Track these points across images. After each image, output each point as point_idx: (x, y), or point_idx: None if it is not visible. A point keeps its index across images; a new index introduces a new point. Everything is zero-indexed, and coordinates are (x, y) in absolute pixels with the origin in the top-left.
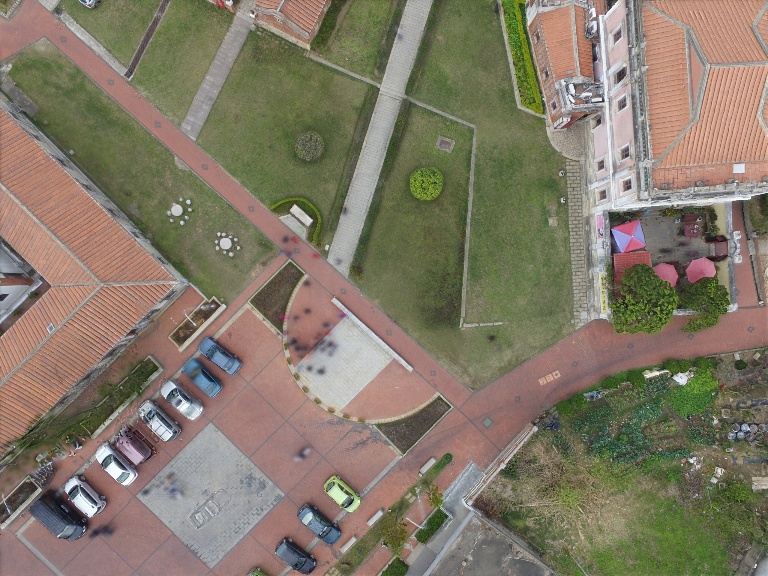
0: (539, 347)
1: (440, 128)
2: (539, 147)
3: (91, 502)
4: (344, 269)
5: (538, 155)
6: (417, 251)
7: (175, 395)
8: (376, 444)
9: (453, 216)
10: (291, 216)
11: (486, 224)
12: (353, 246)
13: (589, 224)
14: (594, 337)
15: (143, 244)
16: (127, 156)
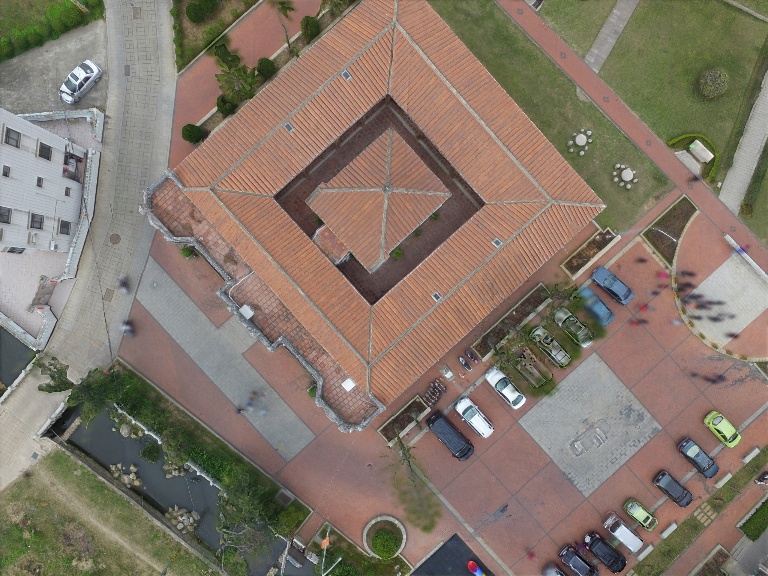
0: None
1: None
2: None
3: (488, 423)
4: (735, 207)
5: None
6: None
7: (575, 321)
8: (754, 382)
9: None
10: (686, 152)
11: None
12: (745, 185)
13: None
14: None
15: None
16: (529, 85)
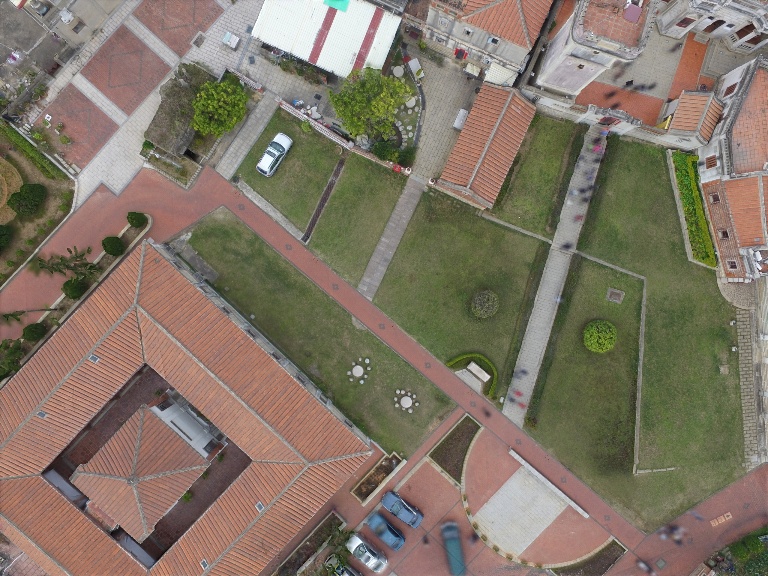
0: (710, 490)
1: (610, 280)
2: (710, 298)
3: None
4: (519, 420)
5: (709, 305)
6: (589, 400)
7: (363, 552)
8: None
9: (624, 365)
10: (466, 371)
11: (658, 373)
12: (527, 398)
13: (759, 371)
14: (765, 479)
15: (331, 410)
16: (305, 317)
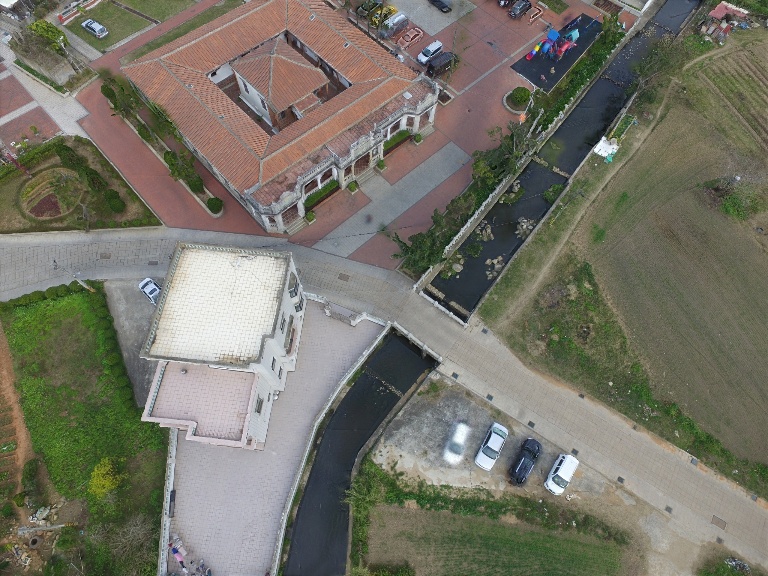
0: None
1: None
2: None
3: None
4: None
5: None
6: None
7: None
8: None
9: None
10: None
11: None
12: None
13: None
14: None
15: None
16: None
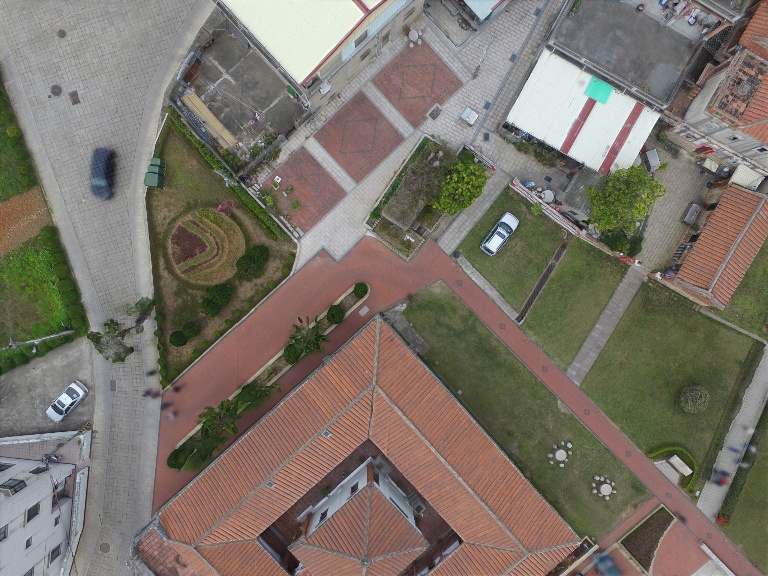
0: None
1: None
2: None
3: None
4: (712, 515)
5: None
6: None
7: None
8: None
9: None
10: (666, 462)
11: None
12: (723, 493)
13: None
14: None
15: None
16: (511, 397)
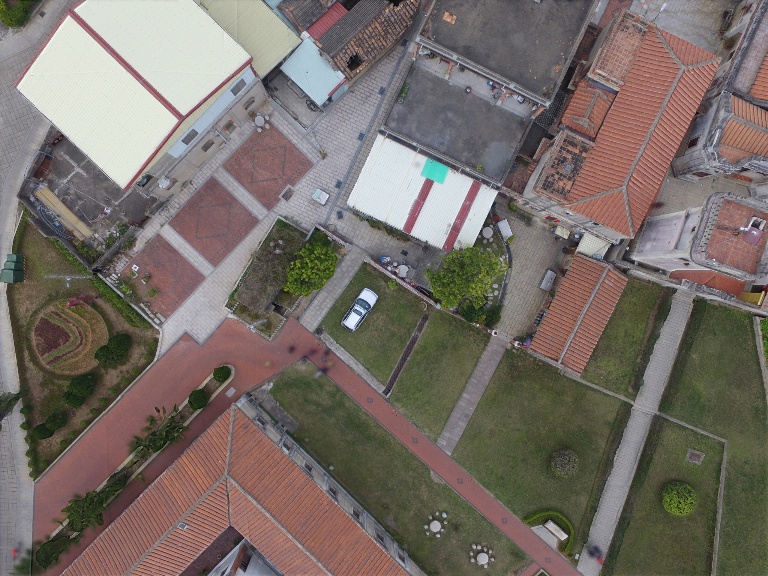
0: None
1: (690, 441)
2: None
3: None
4: None
5: None
6: (664, 559)
7: None
8: None
9: (701, 526)
10: (542, 526)
11: (735, 536)
12: (602, 555)
13: None
14: None
15: (410, 568)
16: (383, 469)
